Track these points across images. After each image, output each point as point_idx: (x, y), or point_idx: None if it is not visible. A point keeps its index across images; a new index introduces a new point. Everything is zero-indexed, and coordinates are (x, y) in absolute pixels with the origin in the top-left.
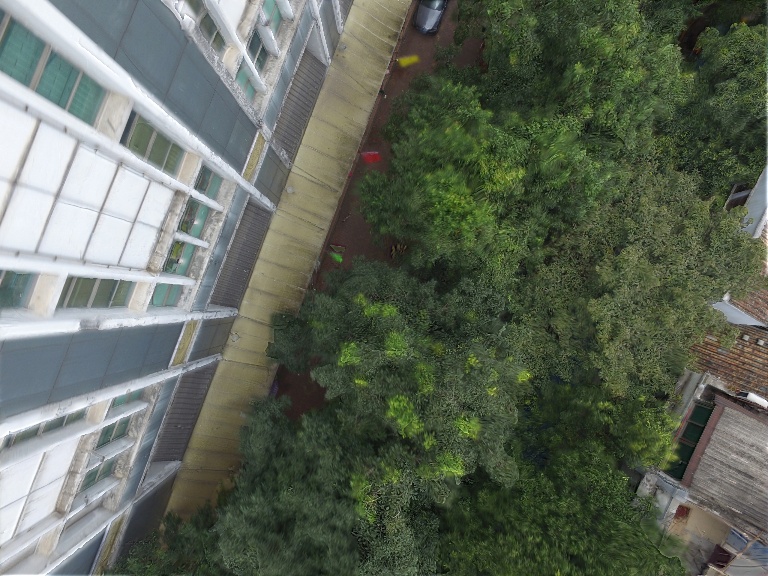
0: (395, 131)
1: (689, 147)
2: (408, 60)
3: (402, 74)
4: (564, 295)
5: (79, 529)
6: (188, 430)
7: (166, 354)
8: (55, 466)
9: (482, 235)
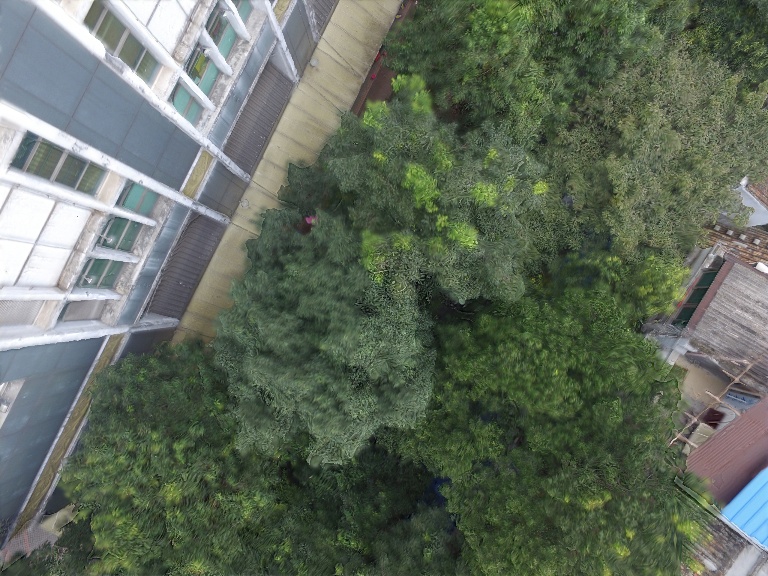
0: (426, 11)
1: (721, 41)
2: None
3: None
4: (582, 161)
5: (77, 325)
6: (189, 290)
7: (179, 173)
8: (63, 231)
9: (511, 61)
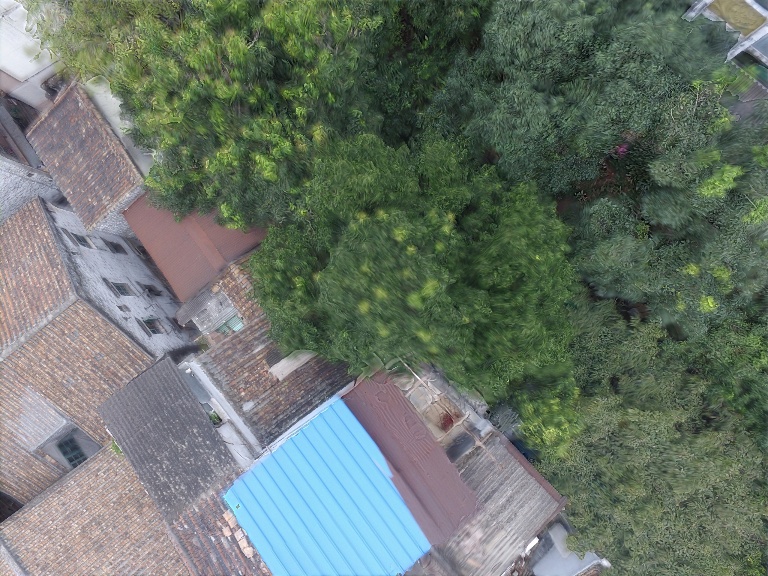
0: None
1: None
2: None
3: None
4: None
5: None
6: None
7: None
8: None
9: None
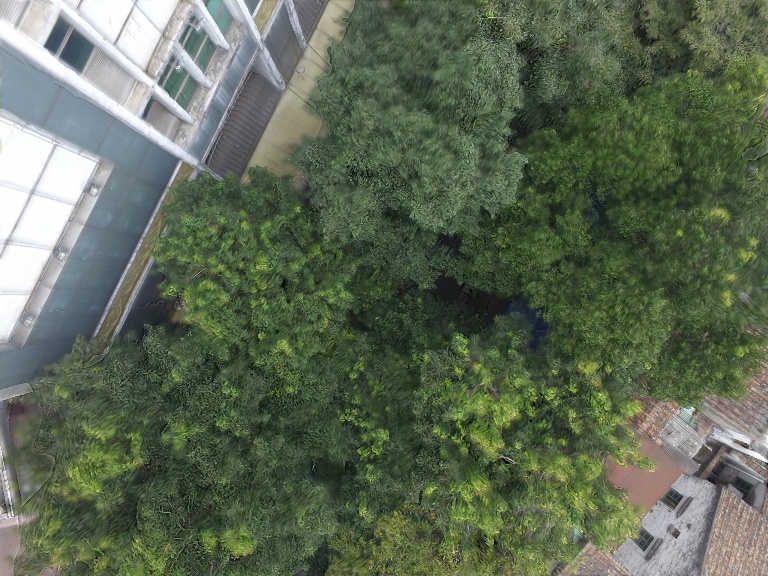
0: None
1: None
2: None
3: None
4: None
5: None
6: (245, 155)
7: None
8: (157, 4)
9: None
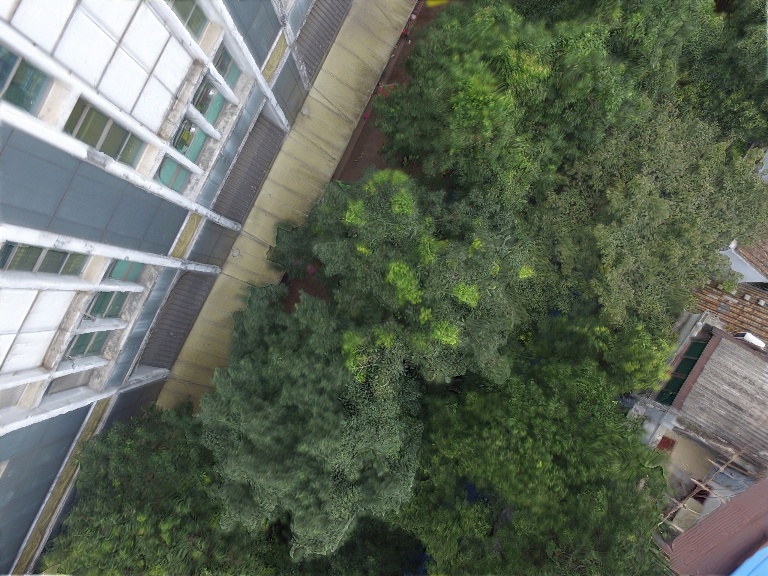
0: (417, 61)
1: (711, 99)
2: (436, 8)
3: (428, 21)
4: (571, 225)
5: (63, 397)
6: (180, 340)
7: (167, 239)
8: (46, 315)
9: (497, 138)
